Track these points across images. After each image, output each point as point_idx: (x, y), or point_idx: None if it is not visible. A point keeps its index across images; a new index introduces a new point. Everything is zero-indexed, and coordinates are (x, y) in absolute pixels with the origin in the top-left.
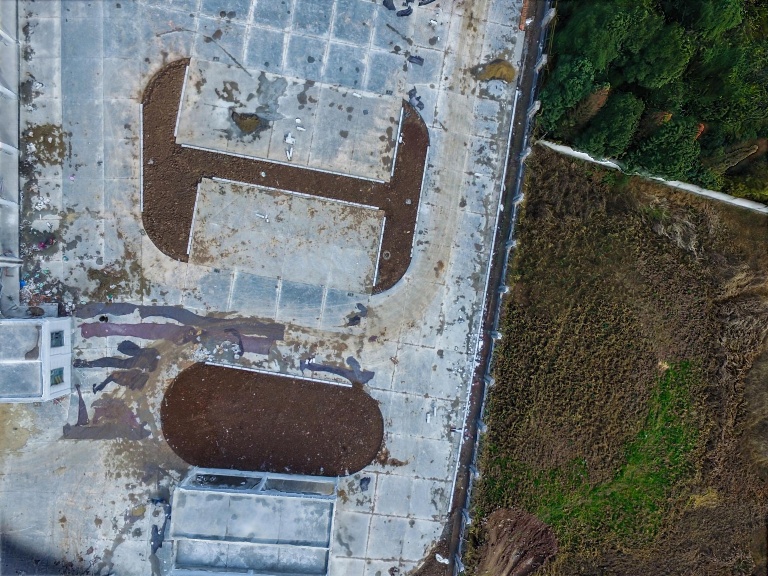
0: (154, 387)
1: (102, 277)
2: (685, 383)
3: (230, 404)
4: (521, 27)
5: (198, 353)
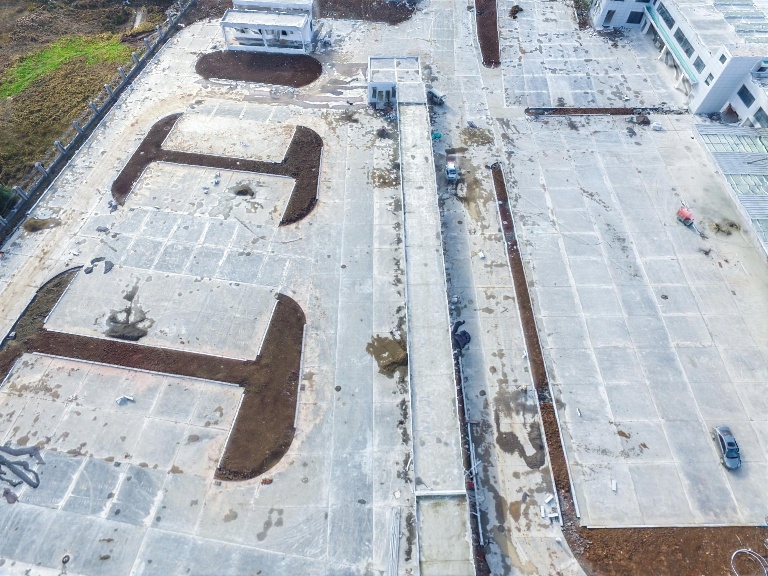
0: (324, 80)
1: (350, 119)
2: (1, 91)
3: (282, 73)
4: (2, 255)
5: (296, 89)
